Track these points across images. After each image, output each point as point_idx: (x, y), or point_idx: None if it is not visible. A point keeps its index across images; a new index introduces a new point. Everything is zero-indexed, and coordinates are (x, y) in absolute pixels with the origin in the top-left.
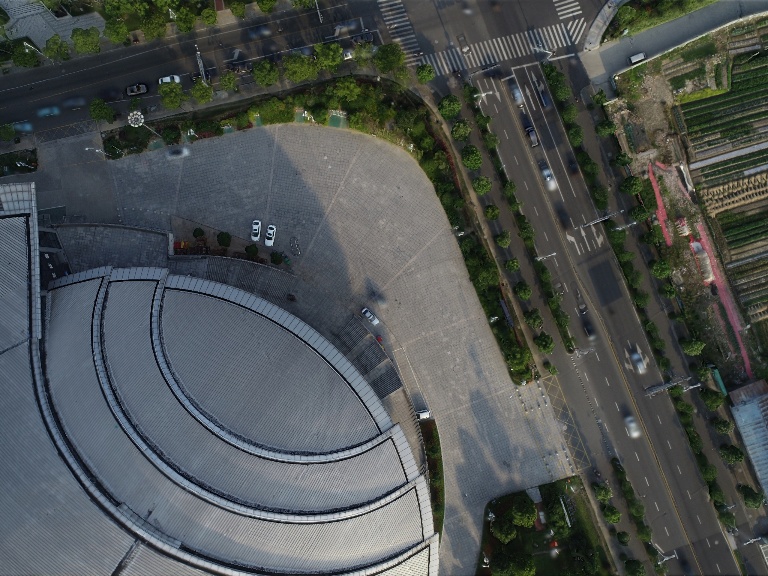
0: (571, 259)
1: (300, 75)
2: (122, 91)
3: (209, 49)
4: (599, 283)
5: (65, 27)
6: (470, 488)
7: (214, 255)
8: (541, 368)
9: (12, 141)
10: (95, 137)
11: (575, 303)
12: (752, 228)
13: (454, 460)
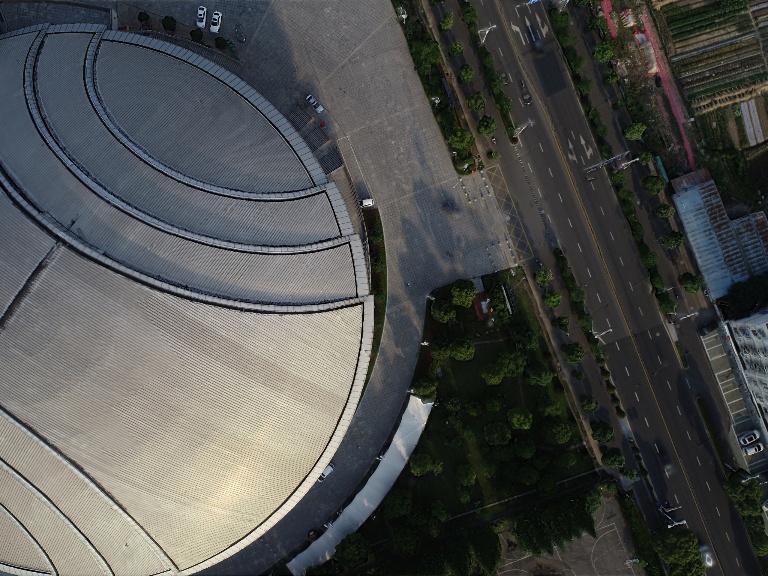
0: (516, 49)
1: None
2: None
3: None
4: (543, 73)
5: None
6: (413, 277)
7: None
8: (485, 158)
9: None
10: None
11: (519, 93)
12: (697, 20)
13: (397, 249)
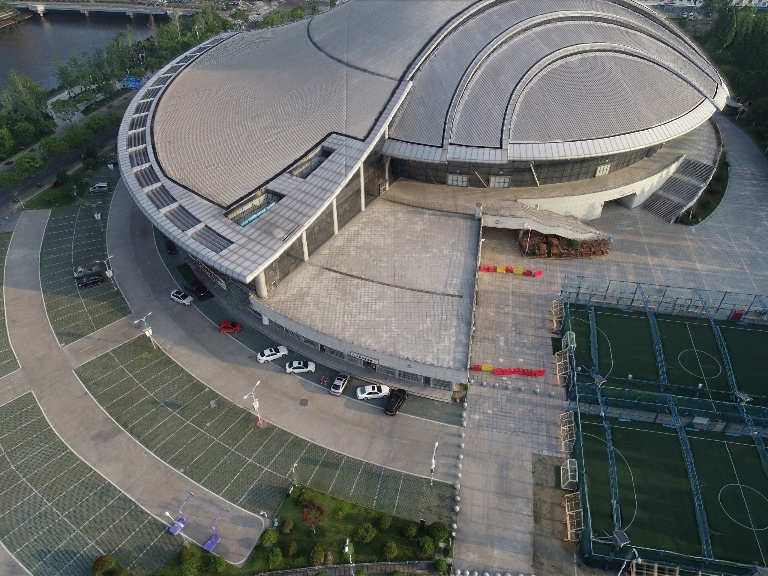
0: None
1: None
2: None
3: None
4: None
5: None
6: None
7: None
8: None
9: None
10: None
11: None
12: None
13: None
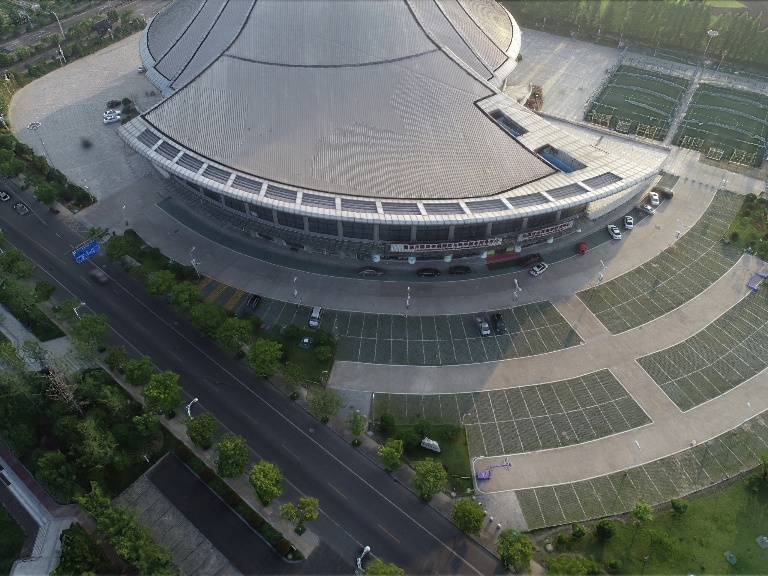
0: (59, 34)
1: None
2: None
3: None
4: (69, 25)
5: None
6: None
7: None
8: None
9: None
10: (80, 216)
11: None
12: None
13: None
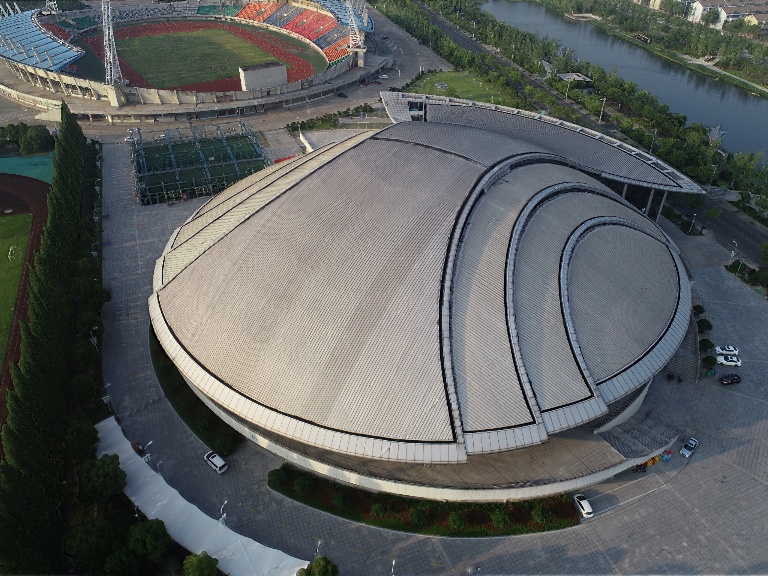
0: None
1: None
2: None
3: None
4: None
5: None
6: (491, 575)
7: None
8: None
9: None
10: None
11: None
12: None
13: (529, 551)
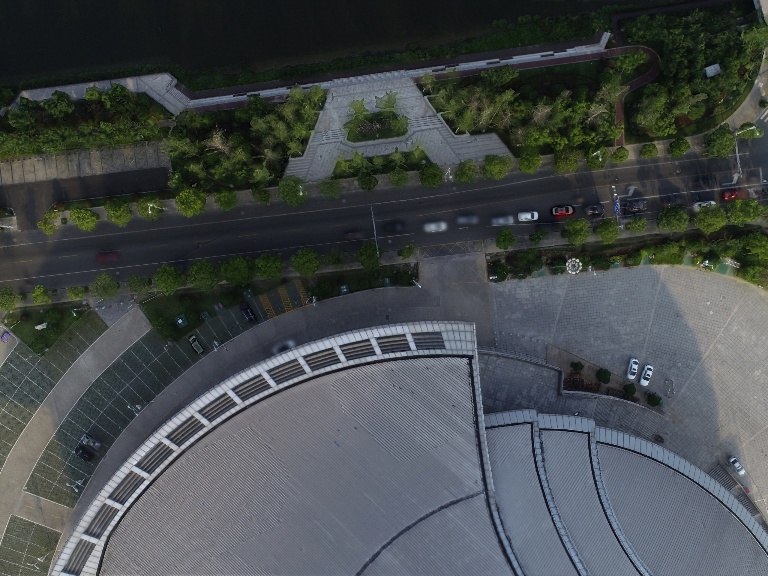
0: None
1: (714, 227)
2: (513, 215)
3: (604, 183)
4: None
5: (461, 145)
6: None
7: (597, 393)
8: None
9: (395, 253)
10: (479, 258)
11: None
12: None
13: None
